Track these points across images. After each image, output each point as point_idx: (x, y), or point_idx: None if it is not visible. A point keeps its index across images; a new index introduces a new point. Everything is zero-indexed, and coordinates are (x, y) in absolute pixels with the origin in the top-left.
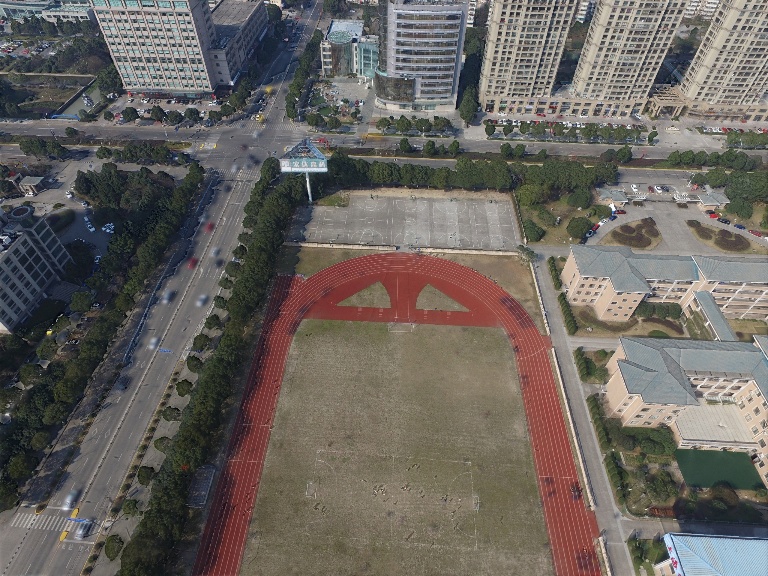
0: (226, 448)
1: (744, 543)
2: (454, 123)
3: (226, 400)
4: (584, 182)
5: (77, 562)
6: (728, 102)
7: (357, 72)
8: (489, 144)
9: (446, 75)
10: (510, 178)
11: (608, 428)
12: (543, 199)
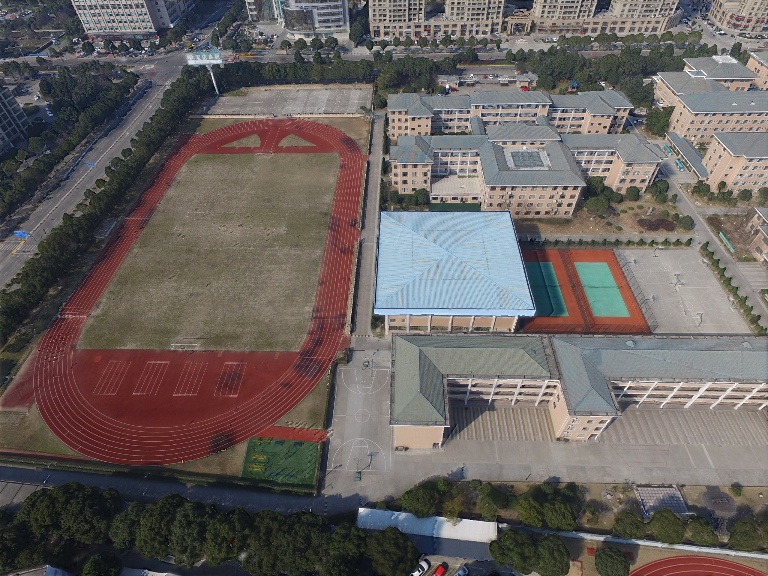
0: (126, 213)
1: (424, 213)
2: (346, 45)
3: (131, 193)
4: (425, 68)
5: (22, 261)
6: (567, 17)
7: (278, 17)
8: (369, 57)
9: (336, 6)
10: (369, 69)
11: (389, 196)
12: (393, 82)
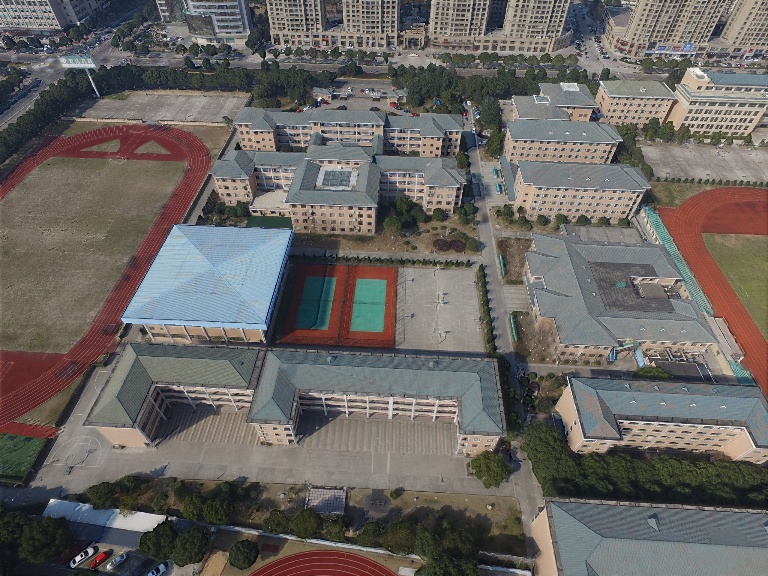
0: None
1: (214, 228)
2: (245, 52)
3: None
4: (298, 81)
5: None
6: (459, 34)
7: None
8: None
9: (234, 13)
10: (246, 79)
11: None
12: (267, 93)
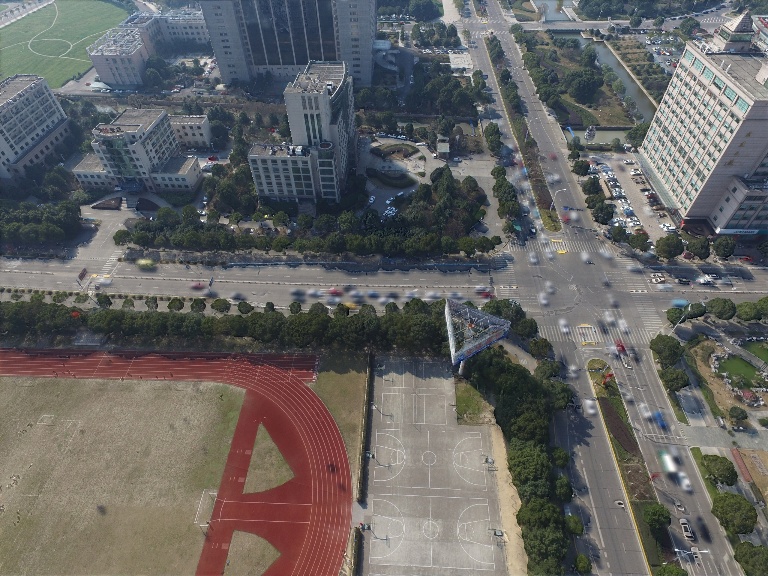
0: (117, 349)
1: None
2: None
3: (165, 340)
4: None
5: (73, 287)
6: None
7: None
8: None
9: None
10: None
11: None
12: None
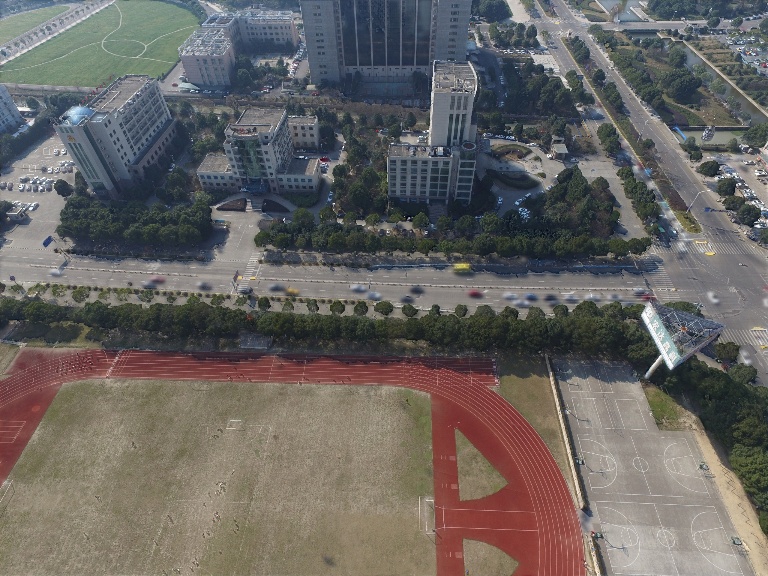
0: (286, 352)
1: None
2: None
3: (331, 343)
4: None
5: (222, 289)
6: None
7: None
8: None
9: None
10: None
11: None
12: None
